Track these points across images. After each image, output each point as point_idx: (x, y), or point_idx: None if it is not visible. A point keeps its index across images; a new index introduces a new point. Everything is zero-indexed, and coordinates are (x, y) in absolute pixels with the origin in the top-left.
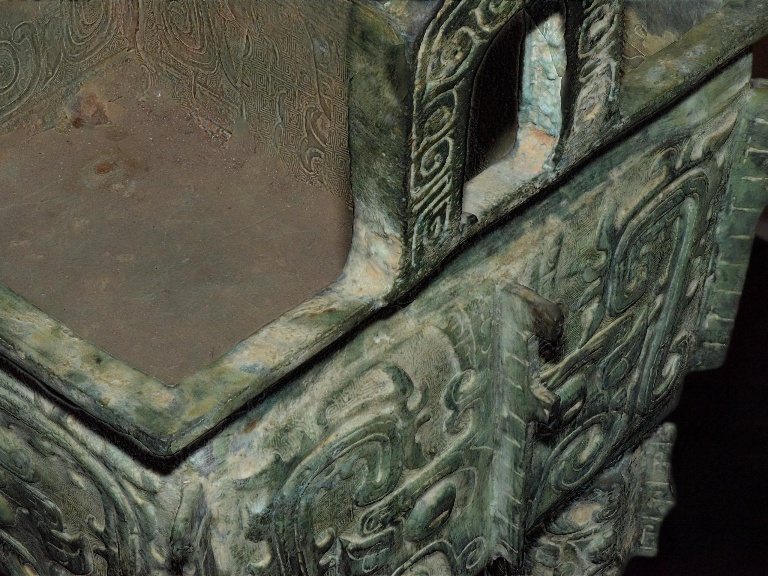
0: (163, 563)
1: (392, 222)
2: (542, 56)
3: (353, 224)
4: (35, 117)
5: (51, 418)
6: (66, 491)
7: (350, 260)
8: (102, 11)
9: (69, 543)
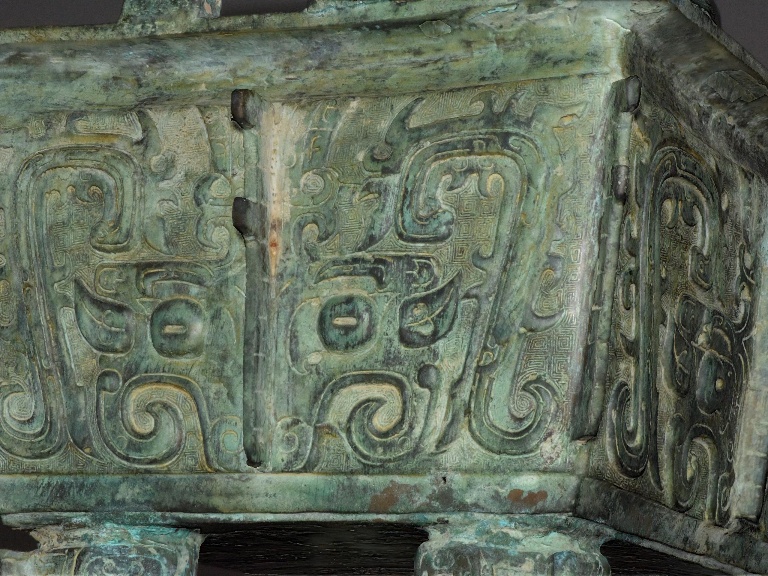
0: None
1: None
2: None
3: None
4: (122, 489)
5: None
6: None
7: None
8: (7, 414)
9: None
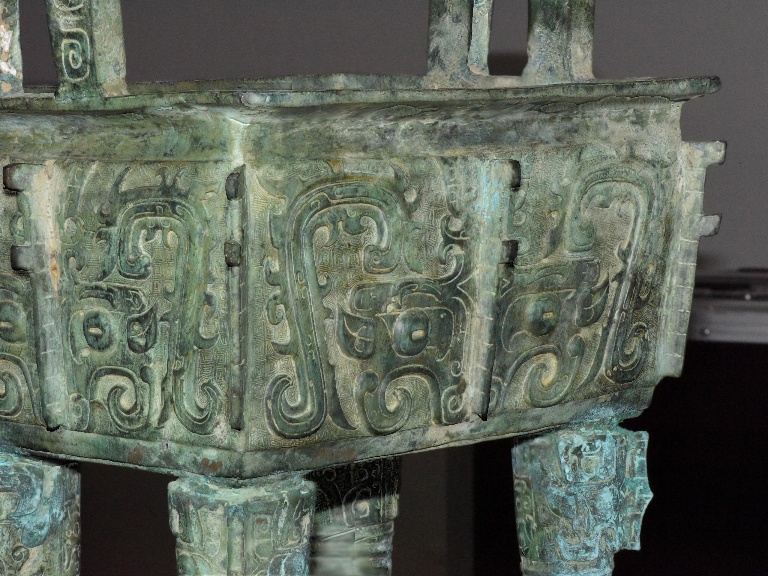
0: (661, 232)
1: (590, 31)
2: (473, 10)
3: (571, 49)
4: None
5: (627, 157)
6: (609, 235)
7: (576, 71)
8: None
9: None
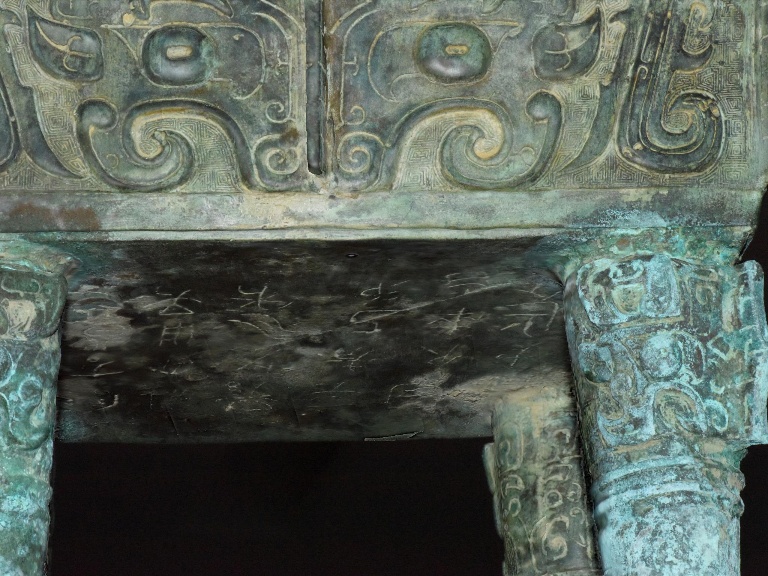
0: None
1: None
2: None
3: None
4: None
5: None
6: None
7: None
8: None
9: (583, 24)
